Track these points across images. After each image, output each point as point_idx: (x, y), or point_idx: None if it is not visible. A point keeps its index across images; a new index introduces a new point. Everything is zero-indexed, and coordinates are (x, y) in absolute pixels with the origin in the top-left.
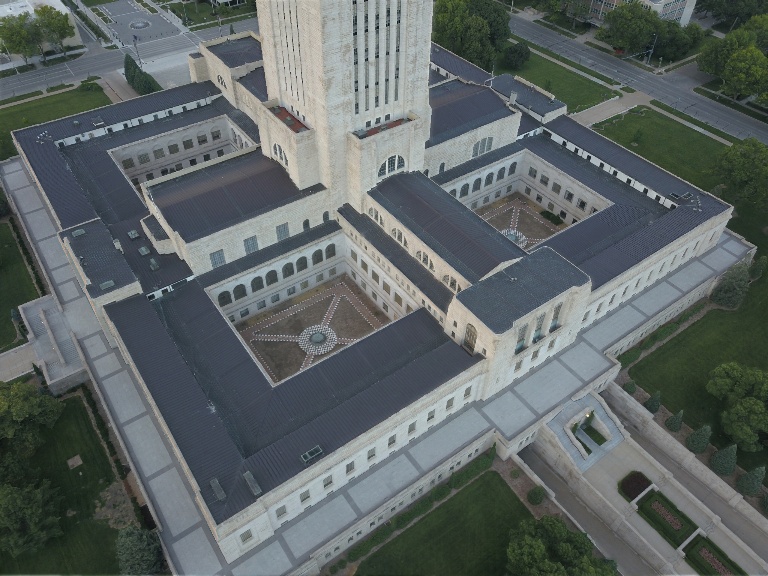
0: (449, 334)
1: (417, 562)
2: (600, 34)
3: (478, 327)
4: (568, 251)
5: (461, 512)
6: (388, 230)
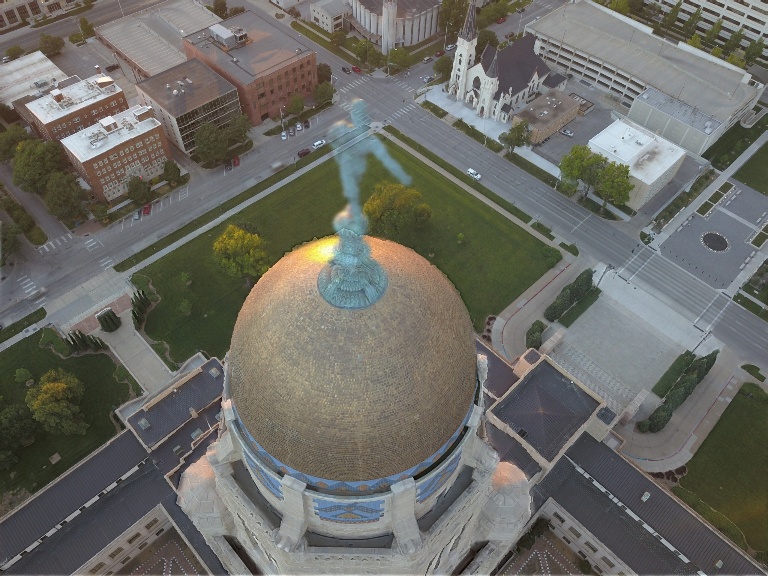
0: None
1: None
2: None
3: None
4: None
5: None
6: None
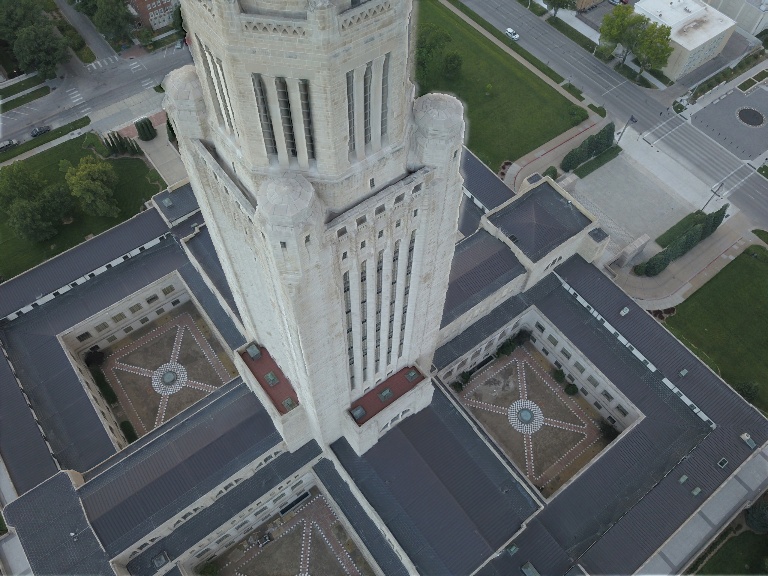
0: None
1: None
2: None
3: None
4: None
5: None
6: None
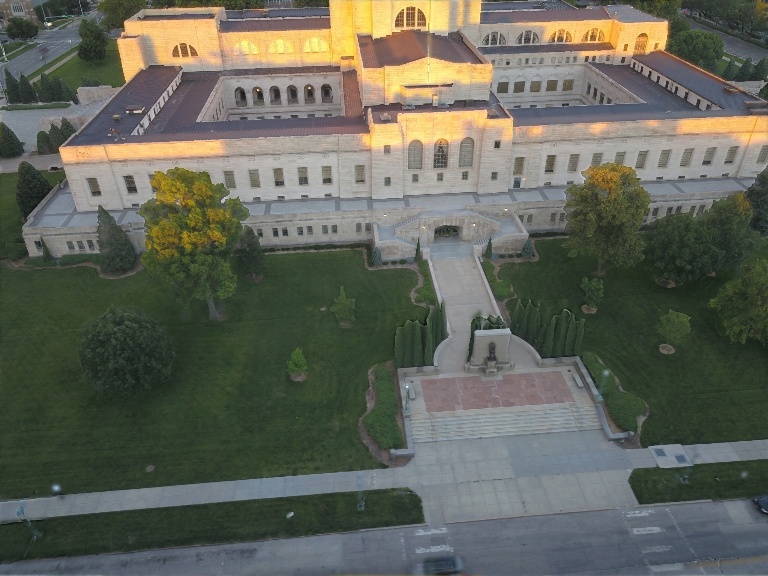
0: (619, 63)
1: None
2: (300, 3)
3: (651, 28)
4: None
5: None
6: (513, 41)
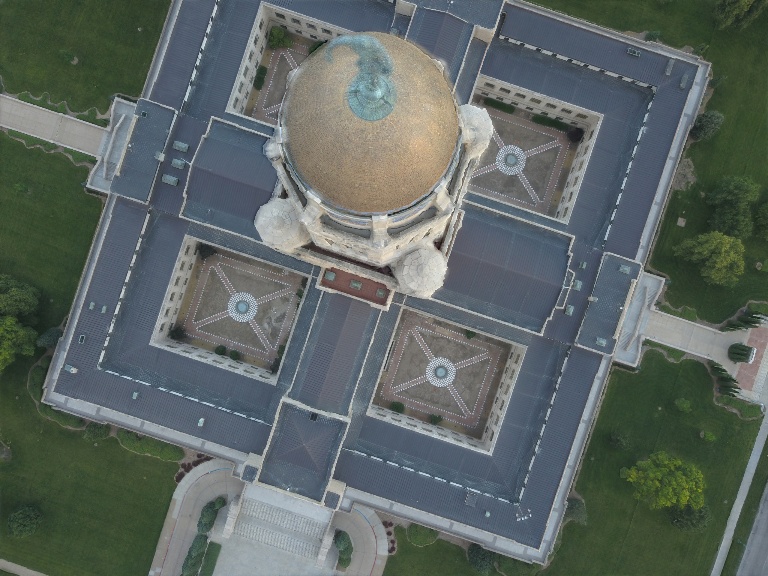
0: None
1: (602, 6)
2: None
3: None
4: (347, 11)
5: (562, 0)
6: None
